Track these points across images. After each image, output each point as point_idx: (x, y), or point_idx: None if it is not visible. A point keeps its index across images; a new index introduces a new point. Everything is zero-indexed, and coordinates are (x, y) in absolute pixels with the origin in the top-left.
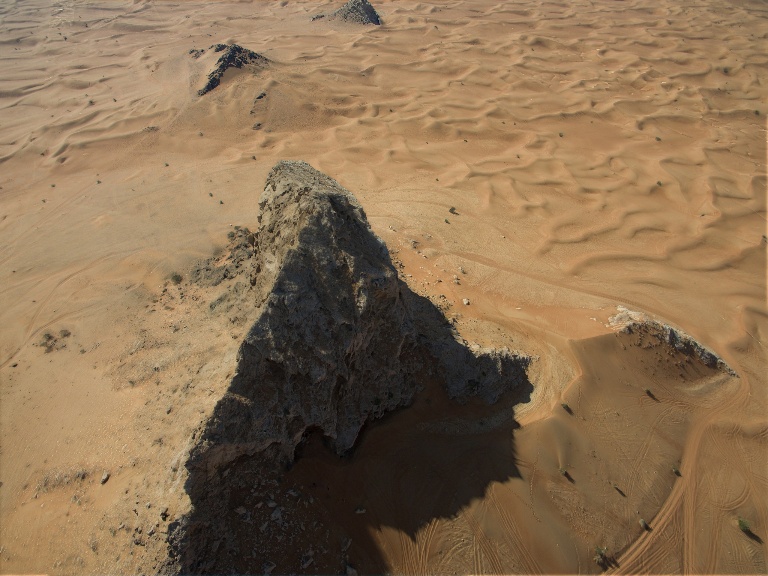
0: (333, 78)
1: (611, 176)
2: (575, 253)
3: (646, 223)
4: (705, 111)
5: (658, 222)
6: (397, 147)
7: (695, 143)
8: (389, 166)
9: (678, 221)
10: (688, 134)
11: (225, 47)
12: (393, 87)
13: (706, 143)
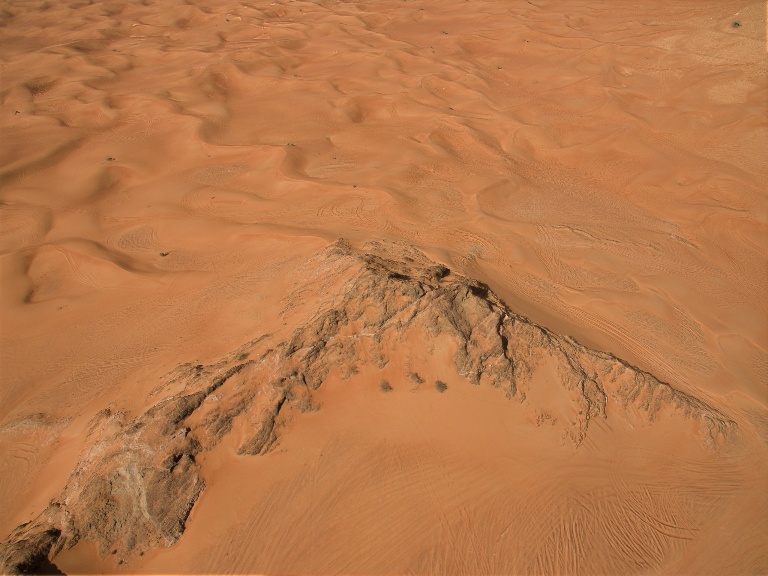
0: (343, 168)
1: (527, 16)
2: (706, 5)
3: (605, 4)
4: (340, 1)
5: (596, 3)
6: (587, 89)
7: (419, 4)
8: (649, 87)
9: (585, 1)
10: (392, 8)
11: (41, 571)
12: (333, 121)
13: (418, 1)
